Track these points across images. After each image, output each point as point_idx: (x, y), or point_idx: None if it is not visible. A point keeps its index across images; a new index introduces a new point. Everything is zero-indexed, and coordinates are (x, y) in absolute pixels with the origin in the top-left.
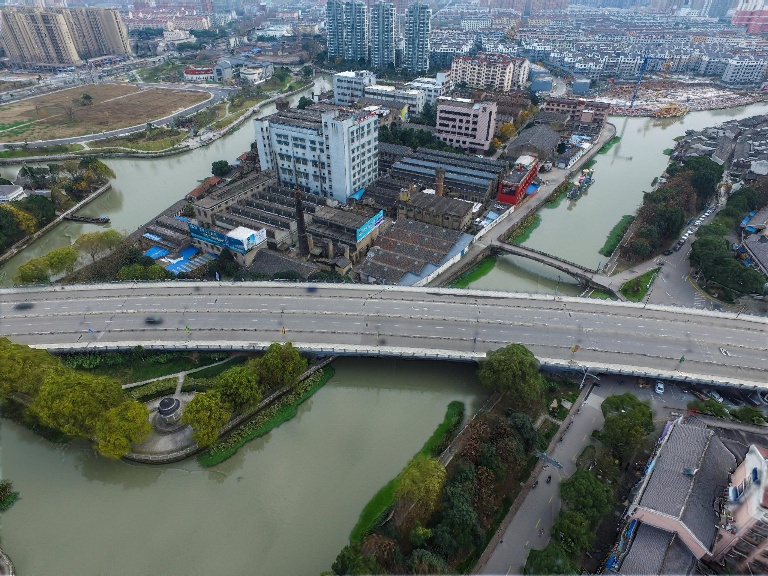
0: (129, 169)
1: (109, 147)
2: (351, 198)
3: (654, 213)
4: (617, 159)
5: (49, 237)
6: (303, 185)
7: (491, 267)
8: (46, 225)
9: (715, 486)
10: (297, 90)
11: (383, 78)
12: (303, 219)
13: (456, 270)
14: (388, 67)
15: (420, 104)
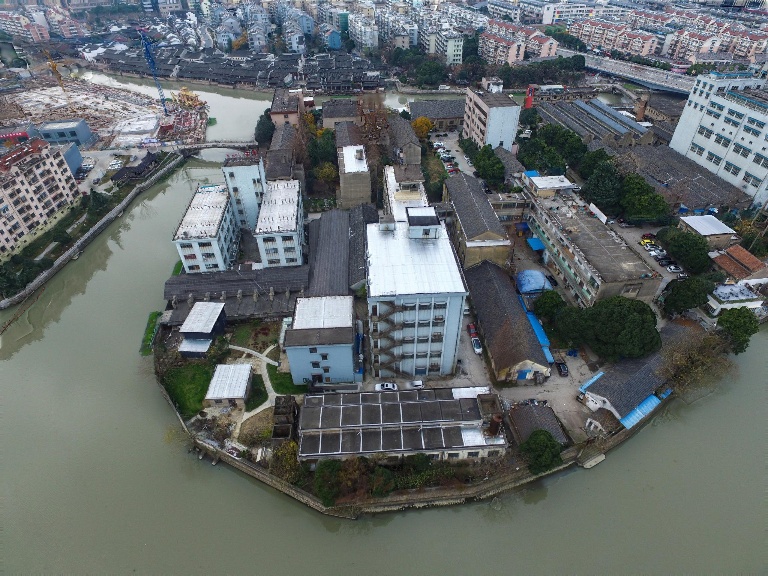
0: None
1: None
2: None
3: (553, 66)
4: (191, 181)
5: None
6: None
7: None
8: None
9: (712, 52)
10: None
11: None
12: None
13: None
14: None
15: None
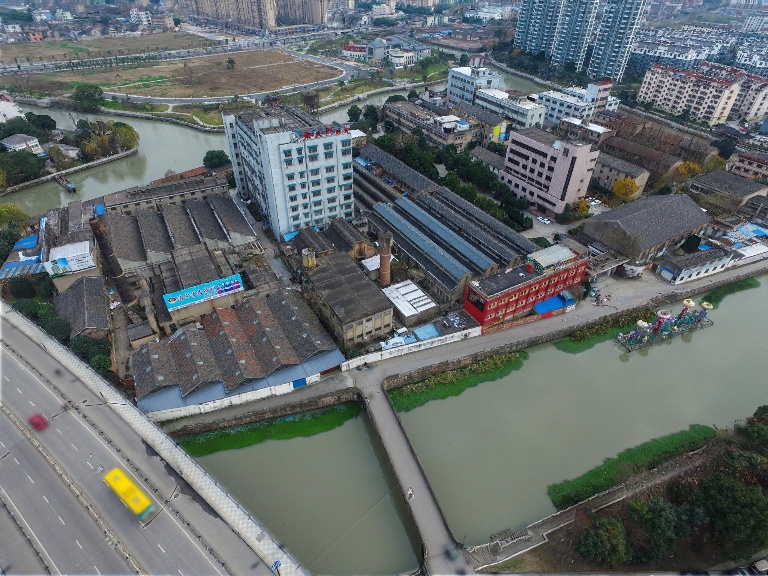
0: (191, 138)
1: (185, 113)
2: (282, 237)
3: (695, 477)
4: None
5: (32, 193)
6: (259, 202)
7: (331, 425)
8: (27, 181)
9: None
10: (434, 81)
11: (552, 81)
12: (110, 258)
13: (258, 410)
14: (565, 67)
15: (534, 123)
